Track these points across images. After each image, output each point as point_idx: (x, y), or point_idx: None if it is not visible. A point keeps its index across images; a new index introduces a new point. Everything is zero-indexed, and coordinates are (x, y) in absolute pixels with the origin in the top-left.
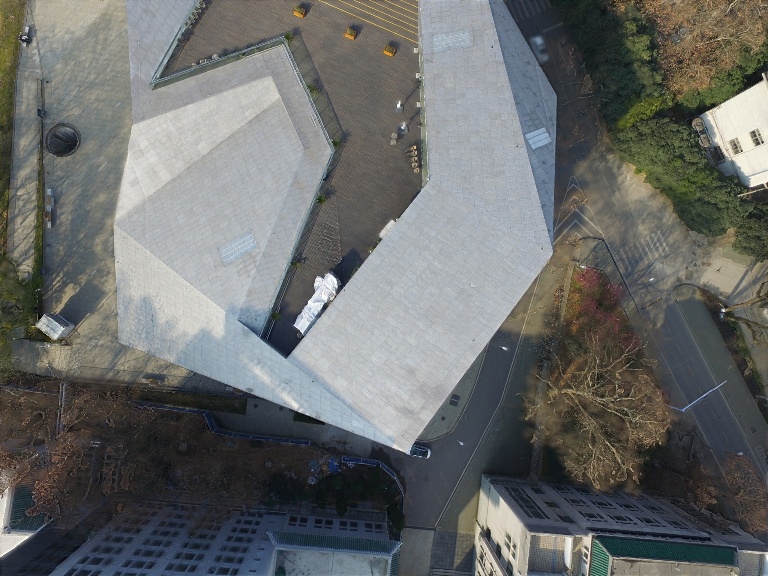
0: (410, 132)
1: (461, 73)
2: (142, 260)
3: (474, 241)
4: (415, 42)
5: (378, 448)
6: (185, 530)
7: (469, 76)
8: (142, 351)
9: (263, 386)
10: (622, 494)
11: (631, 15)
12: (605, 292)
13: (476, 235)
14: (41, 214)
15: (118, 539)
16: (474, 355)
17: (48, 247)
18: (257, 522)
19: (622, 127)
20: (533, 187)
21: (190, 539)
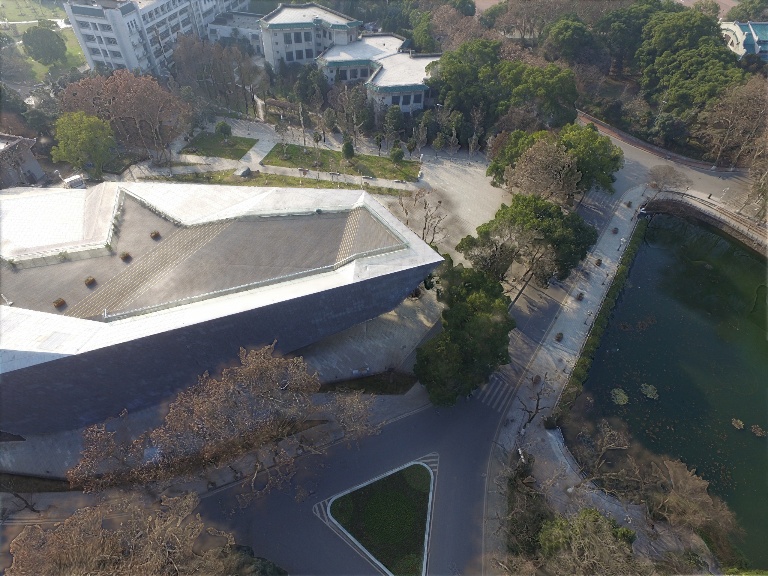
0: None
1: None
2: None
3: None
4: None
5: None
6: None
7: None
8: None
9: None
10: None
11: None
12: None
13: None
14: None
15: None
16: None
17: None
18: None
19: None
20: None
21: None
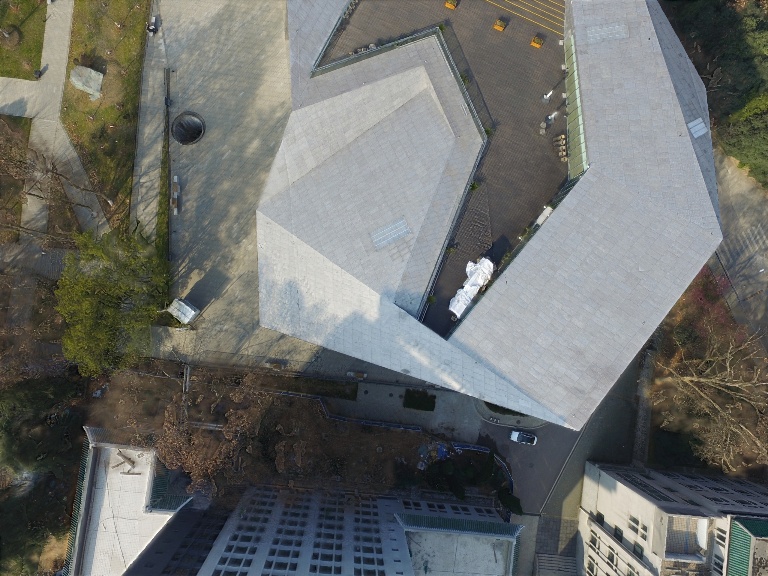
0: (556, 122)
1: (618, 64)
2: (288, 245)
3: (640, 227)
4: (561, 34)
5: (485, 435)
6: (312, 512)
7: (626, 67)
8: (286, 334)
9: (421, 367)
10: (729, 481)
11: (750, 11)
12: (708, 283)
13: (641, 221)
14: (165, 201)
15: (255, 519)
16: (645, 337)
17: (174, 233)
18: (374, 505)
19: (733, 121)
20: (699, 174)
21: (321, 520)
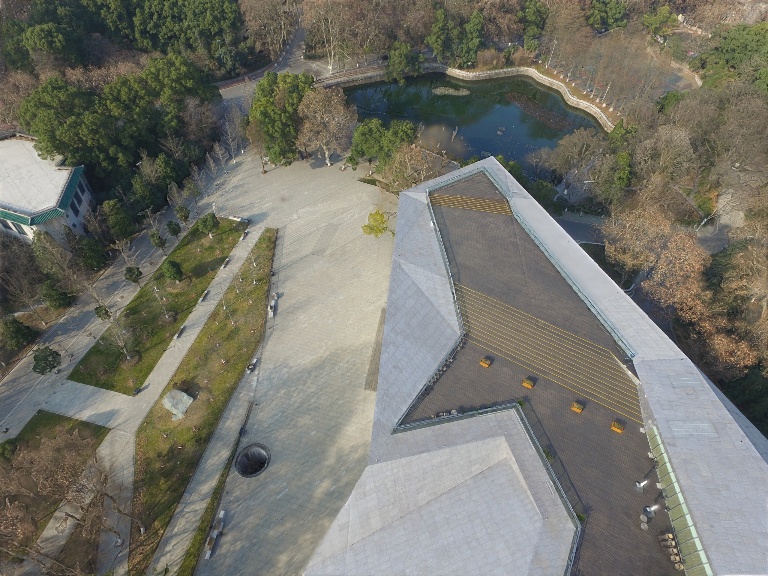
0: (657, 516)
1: (715, 463)
2: None
3: None
4: (640, 422)
5: None
6: None
7: (726, 467)
8: None
9: None
10: None
11: None
12: None
13: None
14: (201, 539)
15: None
16: None
17: None
18: None
19: None
20: None
21: None
